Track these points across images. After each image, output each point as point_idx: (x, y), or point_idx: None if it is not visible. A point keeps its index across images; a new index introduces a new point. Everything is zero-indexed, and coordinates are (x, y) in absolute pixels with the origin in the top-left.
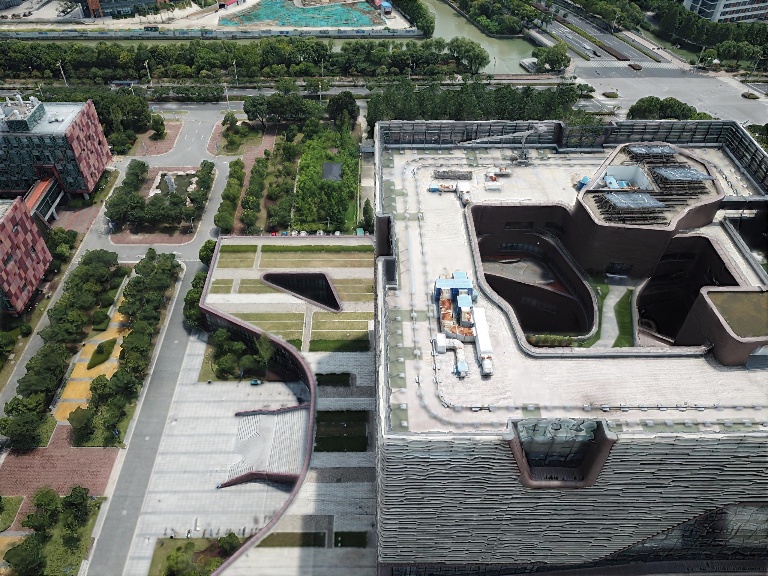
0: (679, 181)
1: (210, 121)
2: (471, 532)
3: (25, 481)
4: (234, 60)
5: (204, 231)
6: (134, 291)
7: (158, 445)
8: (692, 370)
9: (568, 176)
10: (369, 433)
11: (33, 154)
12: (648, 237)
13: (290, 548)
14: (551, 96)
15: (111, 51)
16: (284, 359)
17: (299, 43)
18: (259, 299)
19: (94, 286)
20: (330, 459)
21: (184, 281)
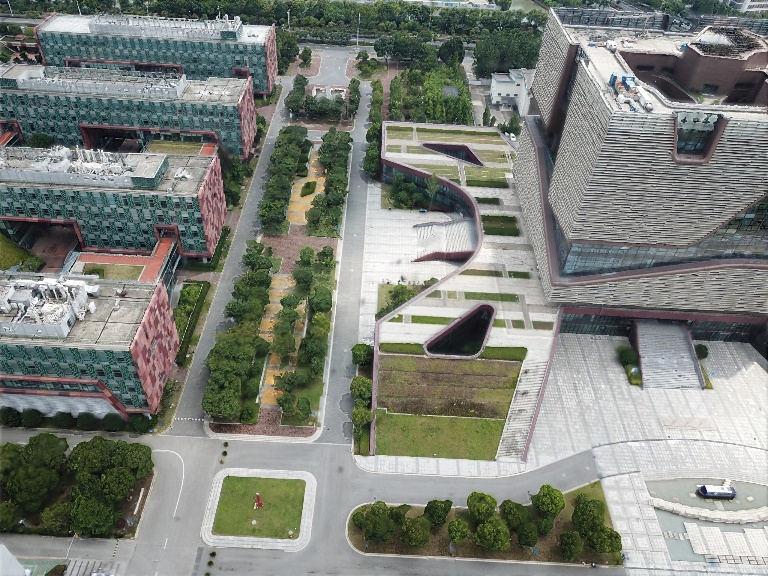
0: (747, 42)
1: (343, 58)
2: (631, 207)
3: (280, 250)
4: (359, 13)
5: (359, 125)
6: (328, 150)
7: (364, 239)
8: (760, 117)
9: (673, 45)
10: (519, 228)
11: (235, 59)
12: (731, 65)
13: (481, 276)
14: None
15: (258, 2)
16: (443, 196)
17: (408, 5)
18: (423, 157)
19: (296, 147)
20: (496, 239)
21: (354, 153)
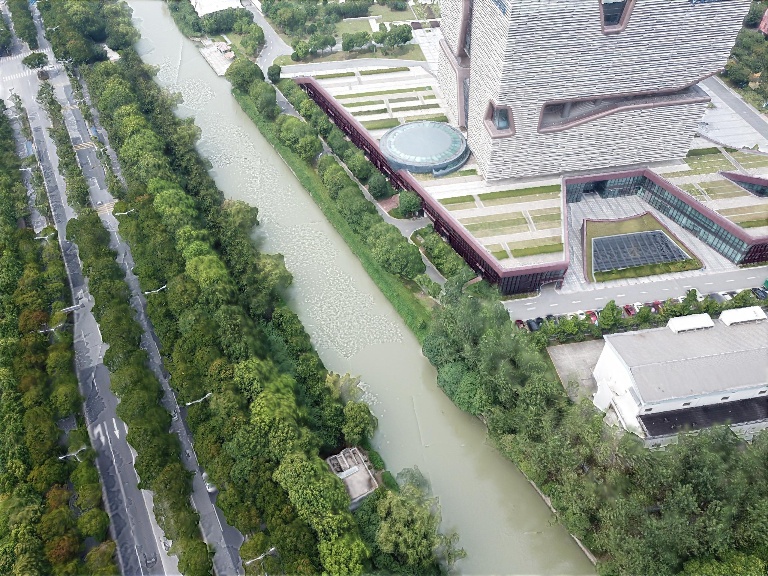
0: None
1: None
2: None
3: None
4: None
5: None
6: None
7: (763, 135)
8: None
9: None
10: None
11: None
12: None
13: None
14: (661, 452)
15: None
16: None
17: None
18: None
19: None
20: None
21: None
